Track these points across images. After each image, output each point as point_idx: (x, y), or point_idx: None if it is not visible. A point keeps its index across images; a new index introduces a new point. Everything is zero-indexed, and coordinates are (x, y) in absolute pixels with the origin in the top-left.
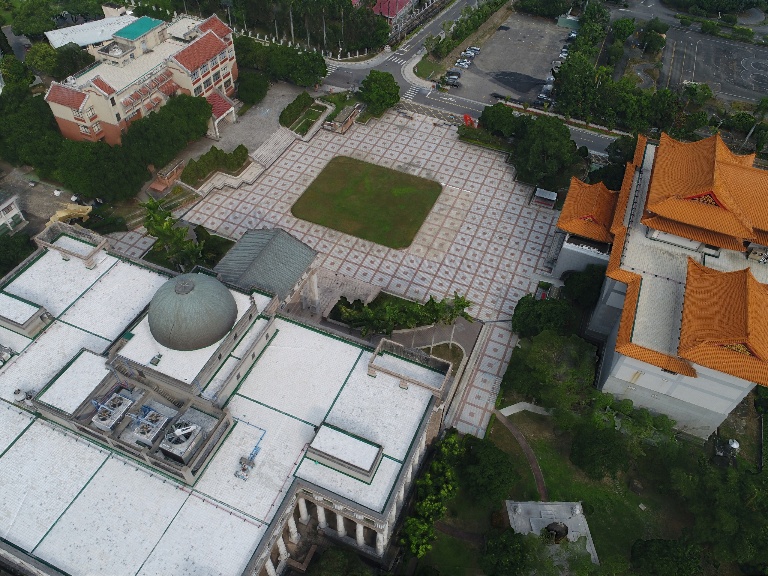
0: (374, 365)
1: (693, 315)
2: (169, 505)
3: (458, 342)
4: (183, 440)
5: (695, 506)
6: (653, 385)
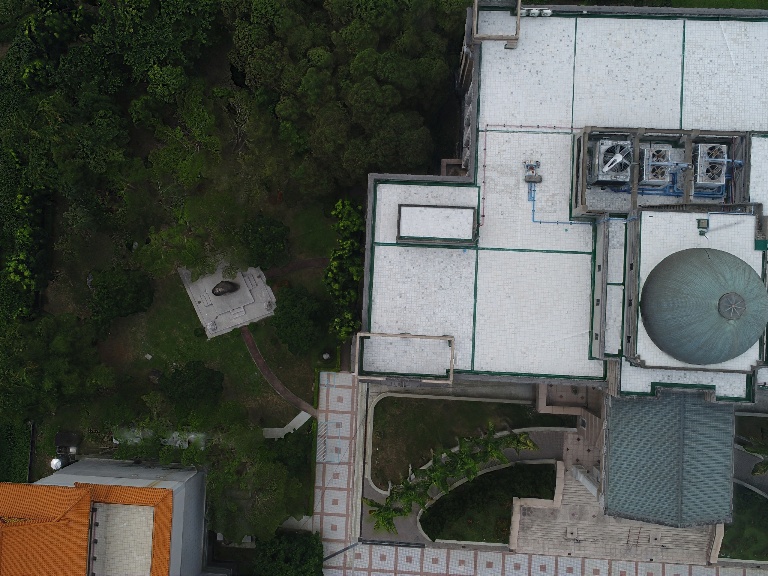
0: (447, 339)
1: (72, 568)
2: (586, 110)
3: (383, 497)
4: (608, 153)
5: (91, 354)
6: (134, 482)
